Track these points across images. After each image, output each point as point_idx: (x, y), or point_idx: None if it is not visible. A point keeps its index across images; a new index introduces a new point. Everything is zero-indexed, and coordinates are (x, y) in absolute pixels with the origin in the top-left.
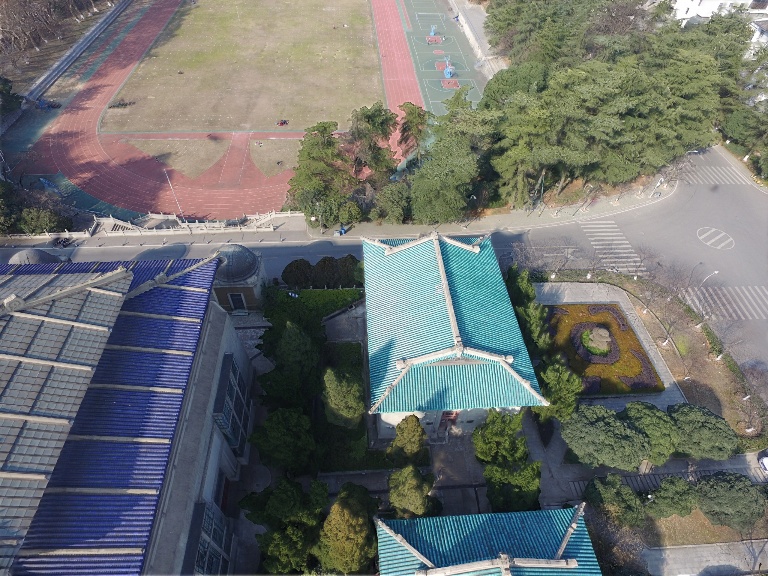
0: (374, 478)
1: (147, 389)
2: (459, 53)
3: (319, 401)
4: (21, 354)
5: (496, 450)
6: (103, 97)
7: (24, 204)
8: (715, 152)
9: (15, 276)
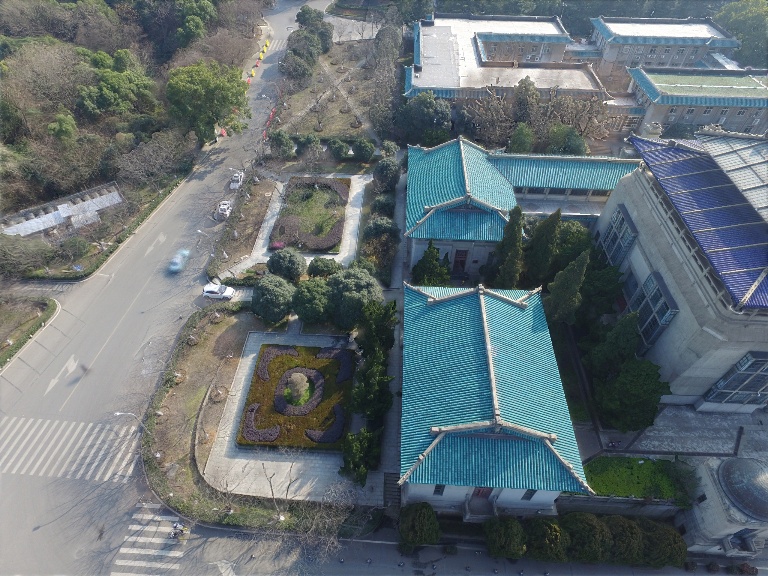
0: None
1: (705, 209)
2: None
3: (575, 365)
4: None
5: None
6: None
7: None
8: None
9: None
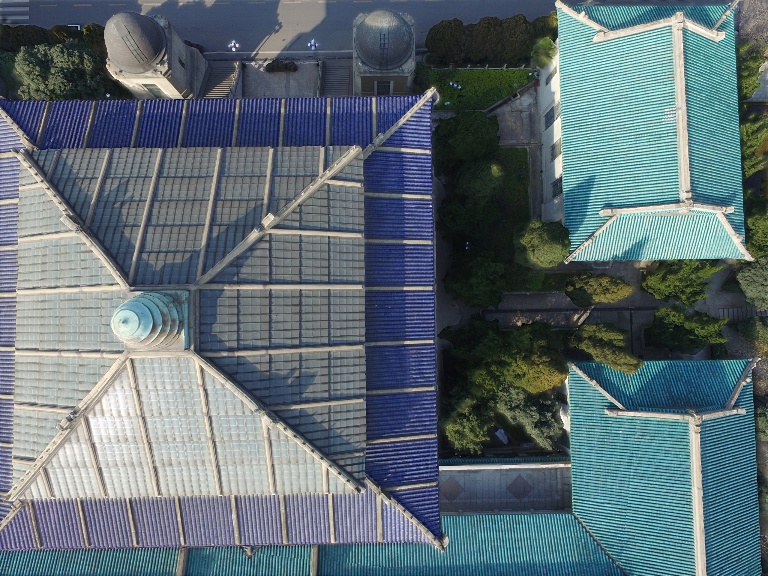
0: (538, 298)
1: (401, 289)
2: None
3: None
4: (298, 281)
5: (672, 291)
6: None
7: None
8: None
9: (223, 151)
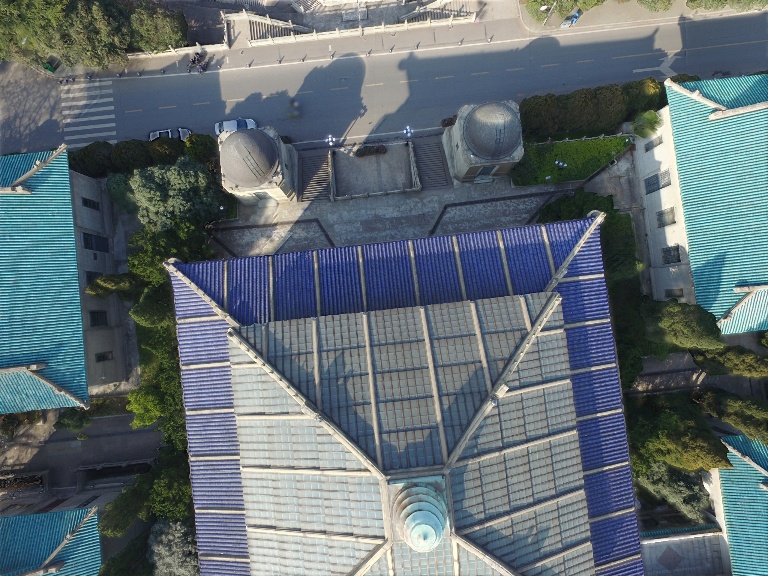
0: (655, 361)
1: (595, 416)
2: None
3: None
4: (525, 439)
5: None
6: None
7: None
8: None
9: (426, 311)
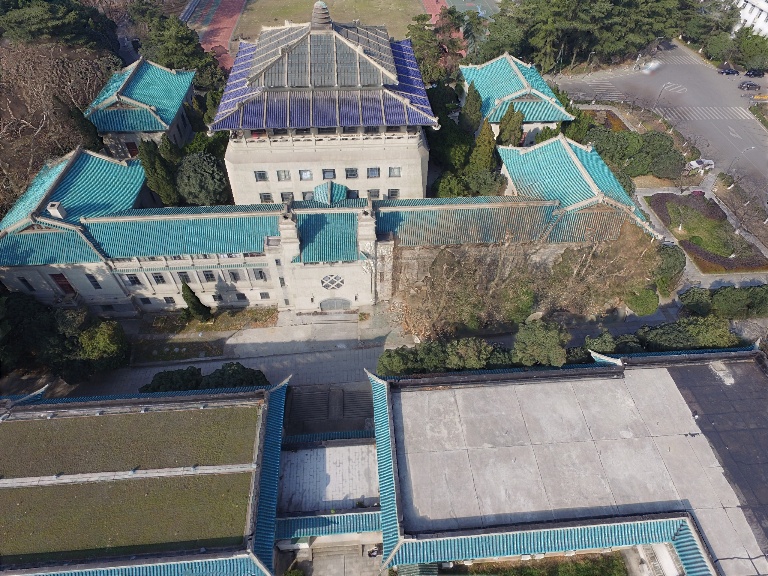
0: None
1: (406, 67)
2: (486, 5)
3: None
4: None
5: None
6: (225, 35)
7: (227, 74)
8: (680, 49)
9: None
